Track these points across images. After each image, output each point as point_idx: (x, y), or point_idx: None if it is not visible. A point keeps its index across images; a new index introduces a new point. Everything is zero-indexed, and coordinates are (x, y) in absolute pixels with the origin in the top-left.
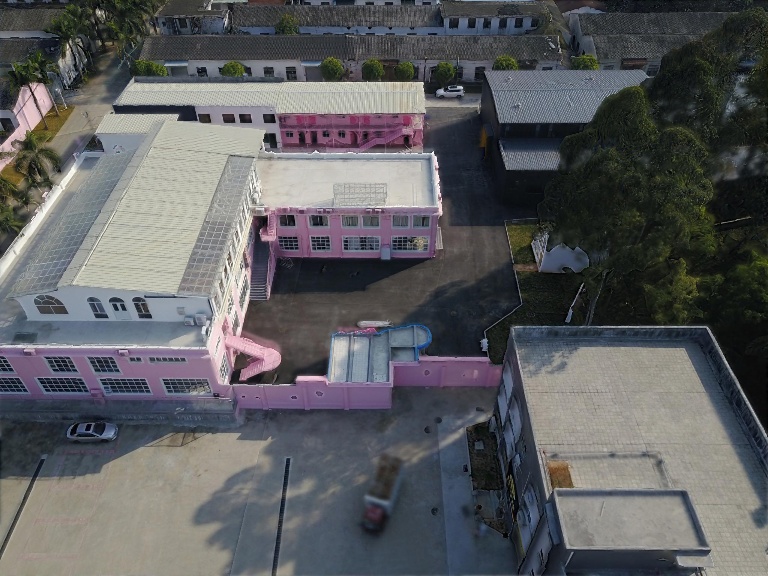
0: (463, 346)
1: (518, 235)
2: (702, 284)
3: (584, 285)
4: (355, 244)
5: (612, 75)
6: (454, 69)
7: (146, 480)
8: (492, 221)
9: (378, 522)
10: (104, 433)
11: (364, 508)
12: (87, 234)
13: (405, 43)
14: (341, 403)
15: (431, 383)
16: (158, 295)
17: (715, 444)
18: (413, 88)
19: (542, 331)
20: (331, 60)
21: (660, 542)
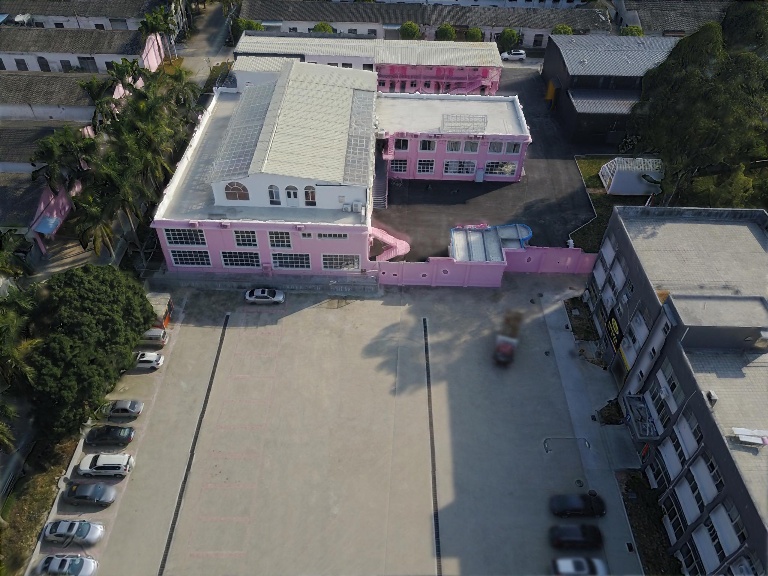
0: (553, 244)
1: (587, 167)
2: (755, 186)
3: None
4: (454, 168)
5: (660, 41)
6: (517, 35)
7: (315, 330)
8: (564, 156)
9: (504, 360)
10: (276, 297)
11: (491, 351)
12: (258, 140)
13: (473, 12)
14: (461, 281)
15: (531, 269)
16: (327, 184)
17: None
18: (490, 46)
19: (638, 211)
20: (410, 24)
21: (748, 324)
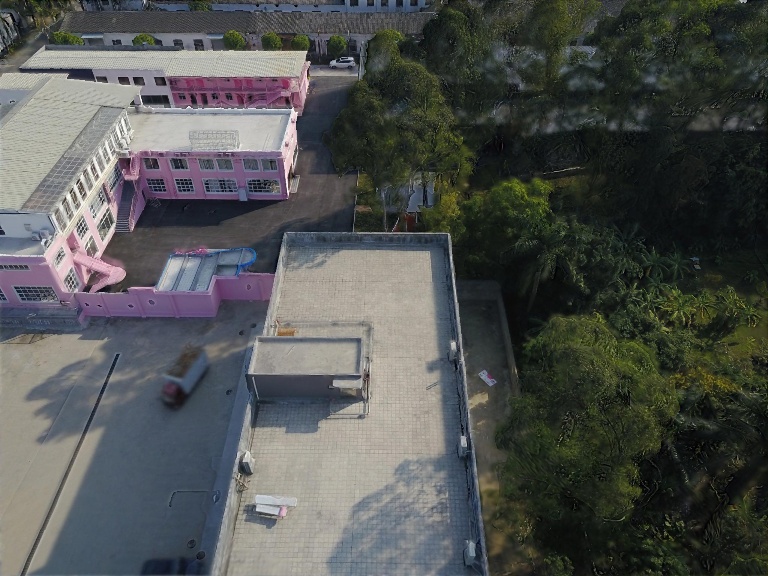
0: None
1: (367, 182)
2: (468, 205)
3: None
4: (216, 187)
5: None
6: (346, 42)
7: None
8: None
9: (179, 400)
10: None
11: (171, 390)
12: None
13: (304, 18)
14: (172, 311)
15: (254, 297)
16: (5, 212)
17: (422, 317)
18: (294, 55)
19: (312, 237)
20: (232, 33)
21: (325, 371)
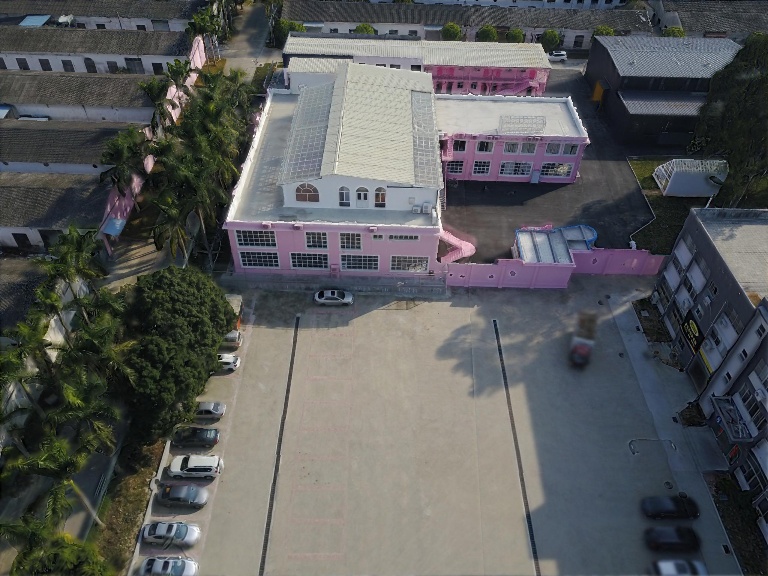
0: (615, 246)
1: (640, 168)
2: None
3: None
4: (510, 169)
5: (706, 42)
6: (559, 36)
7: (387, 331)
8: (616, 157)
9: (579, 361)
10: (345, 298)
11: (565, 352)
12: (325, 141)
13: (514, 13)
14: (528, 282)
15: (596, 271)
16: (399, 185)
17: None
18: (536, 48)
19: (714, 212)
20: (452, 25)
21: None
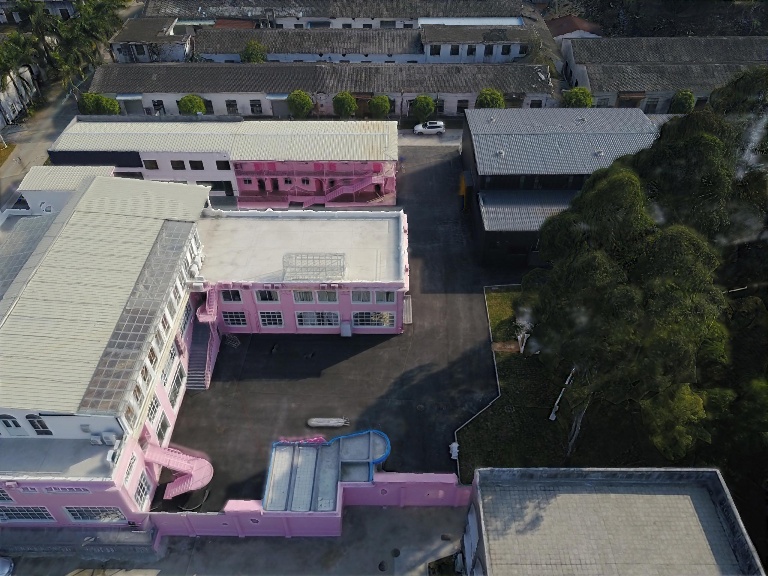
0: (429, 452)
1: (498, 305)
2: (710, 400)
3: (571, 378)
4: (311, 319)
5: (606, 115)
6: (434, 103)
7: None
8: (469, 287)
9: None
10: None
11: None
12: None
13: (381, 73)
14: (281, 530)
15: (389, 502)
16: (55, 413)
17: None
18: (385, 129)
19: (514, 473)
20: (298, 93)
21: None
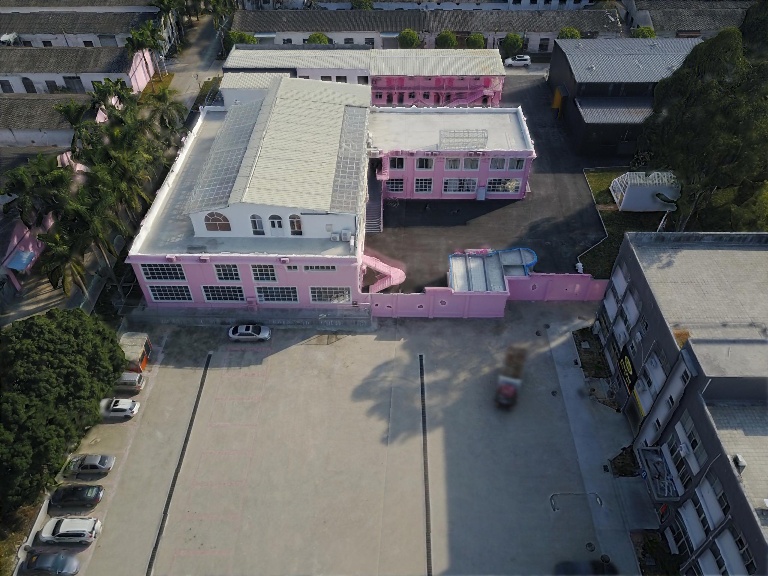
0: (560, 269)
1: (596, 181)
2: None
3: (666, 217)
4: (454, 186)
5: (674, 42)
6: (521, 40)
7: (303, 370)
8: (572, 169)
9: (507, 401)
10: (261, 333)
11: (493, 391)
12: (241, 165)
13: (475, 16)
14: (461, 312)
15: (536, 297)
16: (313, 212)
17: None
18: (491, 54)
19: (651, 237)
20: (409, 31)
21: None
